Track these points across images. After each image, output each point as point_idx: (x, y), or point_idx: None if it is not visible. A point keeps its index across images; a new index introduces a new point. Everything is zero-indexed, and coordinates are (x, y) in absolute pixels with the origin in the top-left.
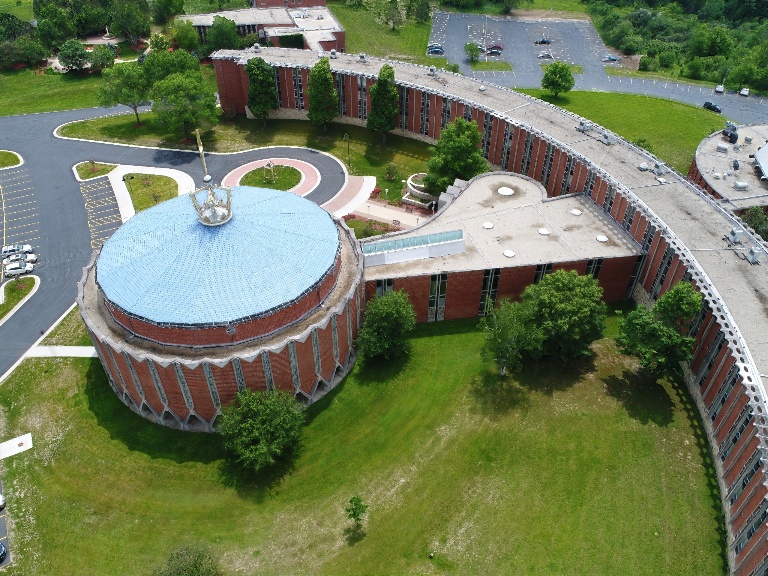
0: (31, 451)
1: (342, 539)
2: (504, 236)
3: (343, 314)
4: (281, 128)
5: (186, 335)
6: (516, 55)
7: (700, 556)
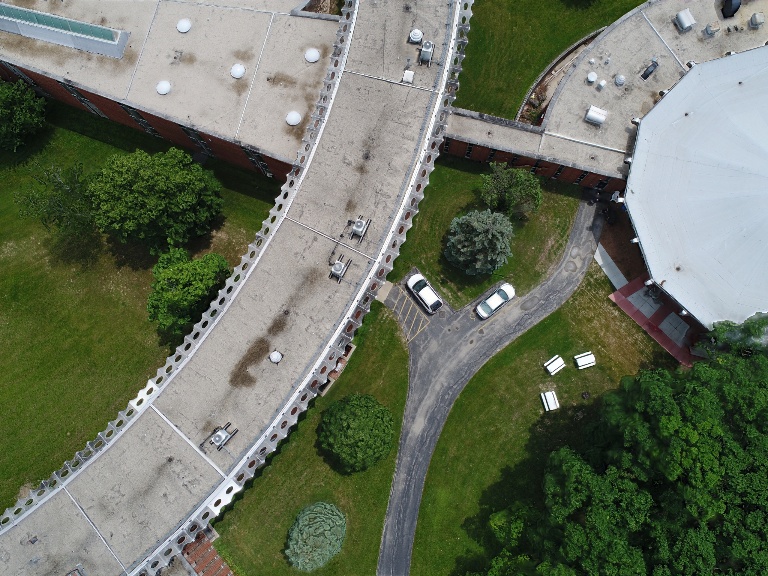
0: None
1: None
2: (187, 54)
3: None
4: None
5: None
6: None
7: None
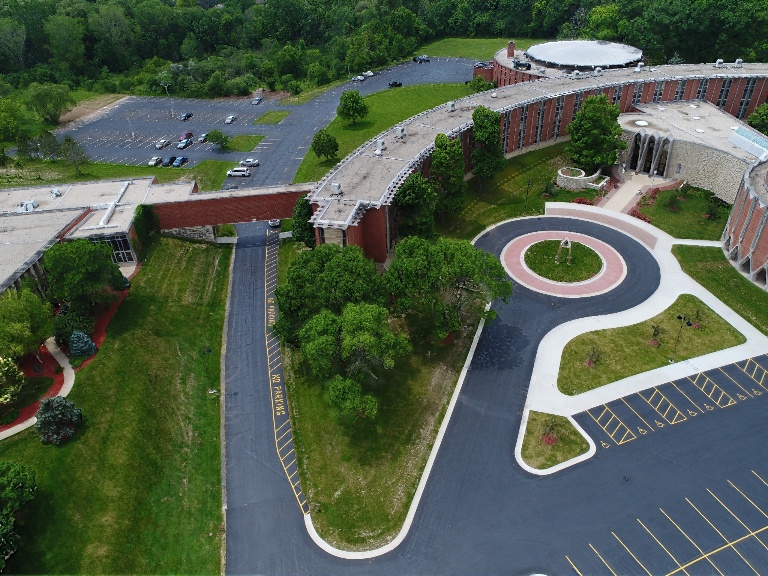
0: None
1: None
2: None
3: None
4: None
5: None
6: None
7: None
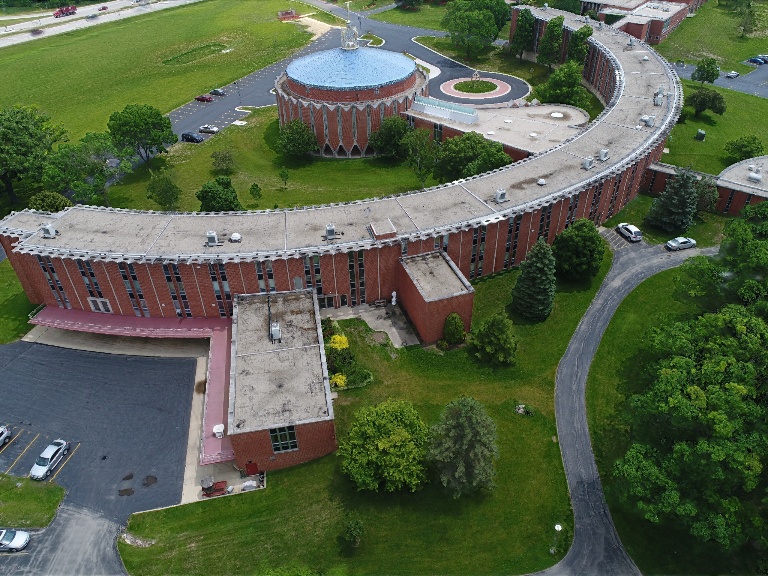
0: (241, 126)
1: (276, 188)
2: (507, 128)
3: (364, 112)
4: (527, 67)
5: (294, 86)
6: None
7: None
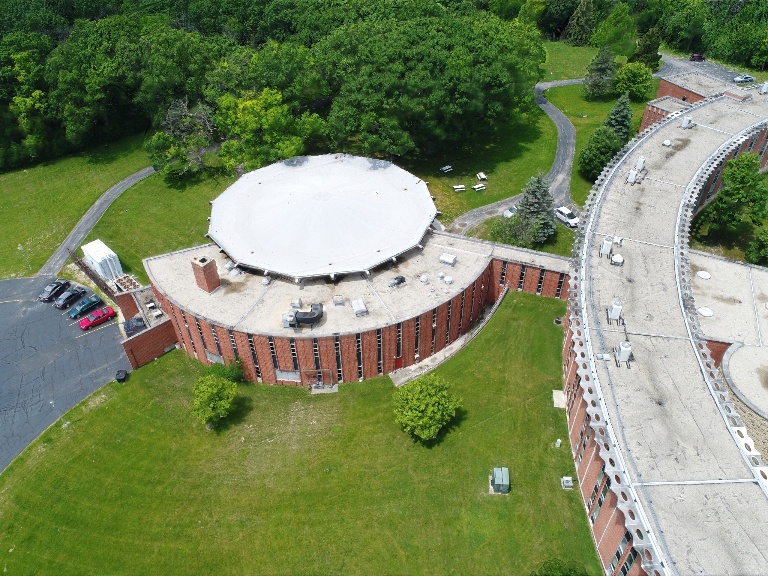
0: None
1: None
2: None
3: None
4: None
5: None
6: None
7: (767, 182)
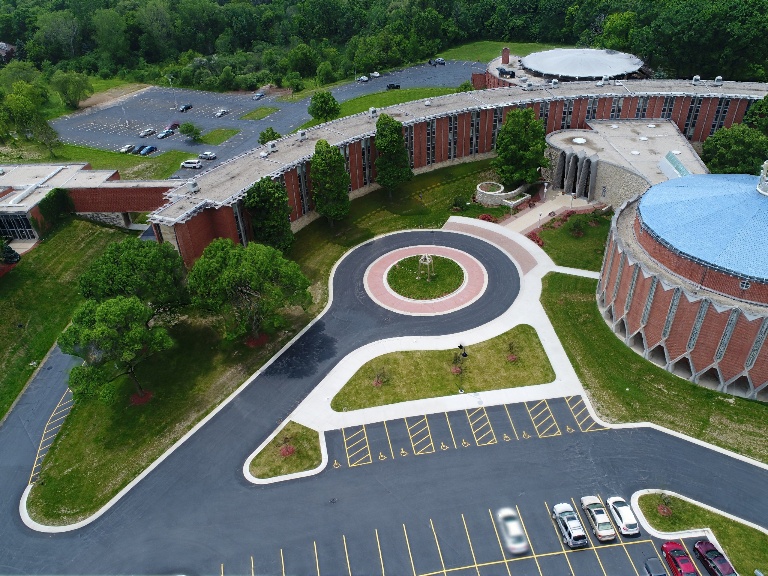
0: None
1: None
2: (649, 151)
3: None
4: (294, 256)
5: None
6: (200, 123)
7: None
